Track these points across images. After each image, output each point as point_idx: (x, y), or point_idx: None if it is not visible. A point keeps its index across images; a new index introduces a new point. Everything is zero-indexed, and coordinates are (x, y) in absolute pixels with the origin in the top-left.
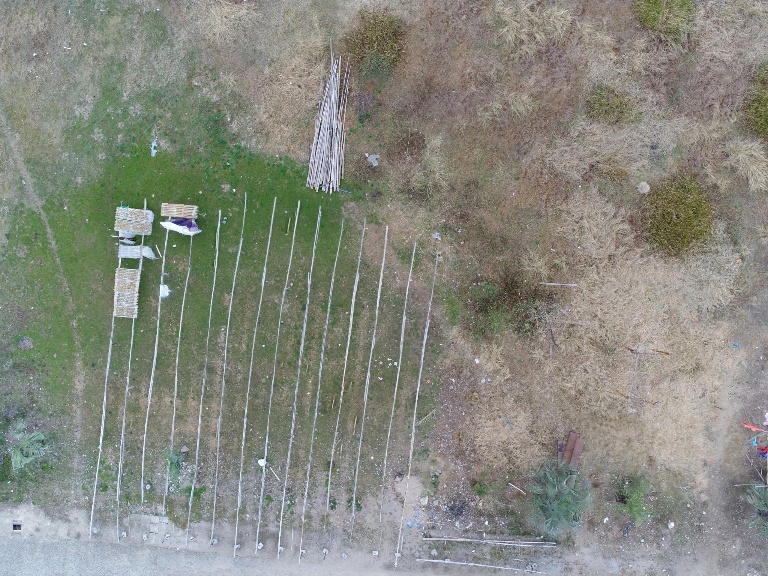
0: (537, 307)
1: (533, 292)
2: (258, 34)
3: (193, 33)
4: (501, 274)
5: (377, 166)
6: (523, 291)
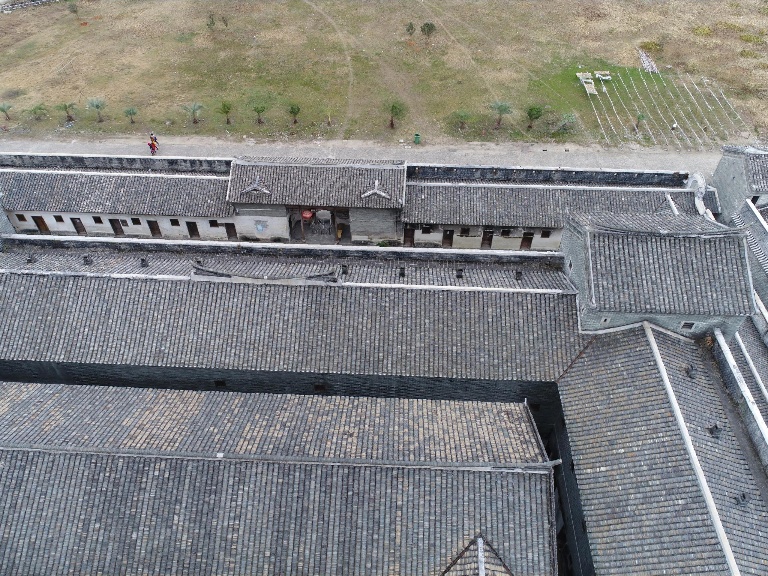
0: (761, 93)
1: (756, 90)
2: (607, 47)
3: (582, 47)
4: (740, 87)
5: (671, 68)
6: (752, 90)
